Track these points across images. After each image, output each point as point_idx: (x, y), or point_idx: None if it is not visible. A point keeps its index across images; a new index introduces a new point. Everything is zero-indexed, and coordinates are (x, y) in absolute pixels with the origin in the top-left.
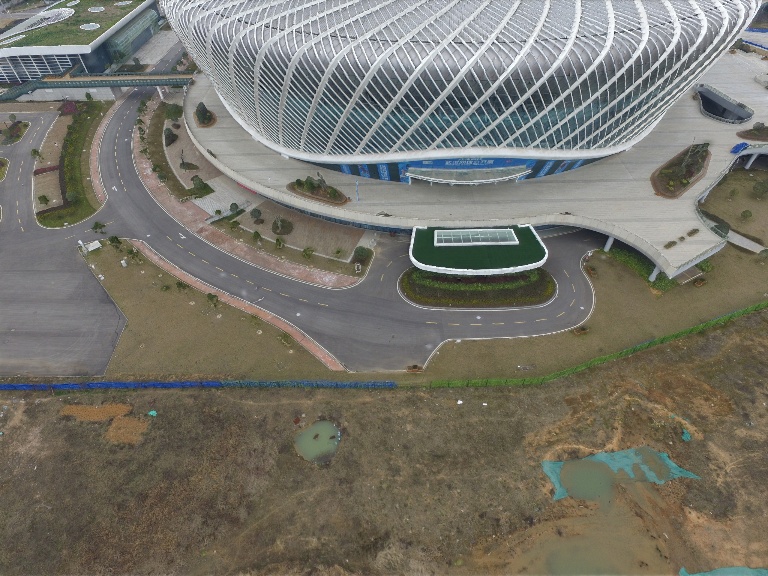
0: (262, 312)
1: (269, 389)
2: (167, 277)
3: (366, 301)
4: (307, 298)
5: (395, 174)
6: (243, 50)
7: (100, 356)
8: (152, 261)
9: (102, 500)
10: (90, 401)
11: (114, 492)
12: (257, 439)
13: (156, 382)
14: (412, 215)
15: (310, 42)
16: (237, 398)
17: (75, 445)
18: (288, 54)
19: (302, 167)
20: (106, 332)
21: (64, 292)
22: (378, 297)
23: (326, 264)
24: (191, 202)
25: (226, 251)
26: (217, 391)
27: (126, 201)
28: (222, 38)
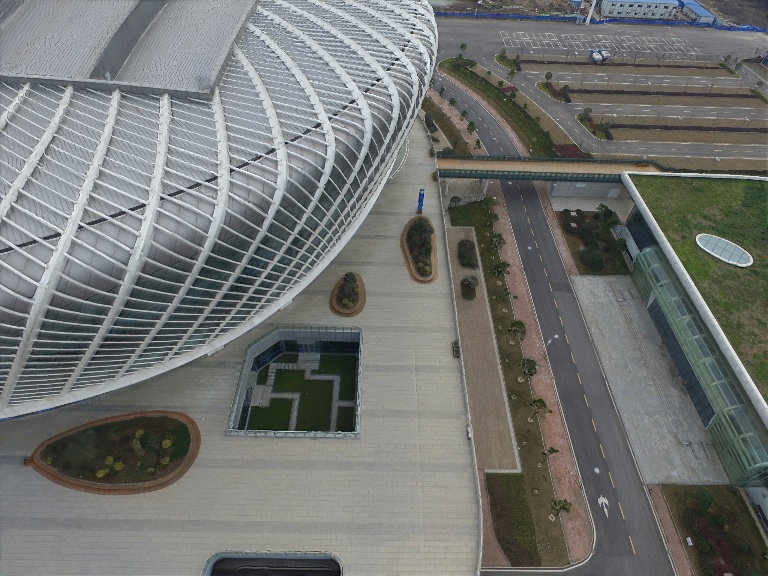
0: None
1: None
2: None
3: None
4: None
5: None
6: None
7: None
8: None
9: None
10: None
11: None
12: None
13: None
14: None
15: None
16: None
17: None
18: None
19: None
20: None
21: None
22: None
23: None
24: None
25: None
26: None
27: None
28: None
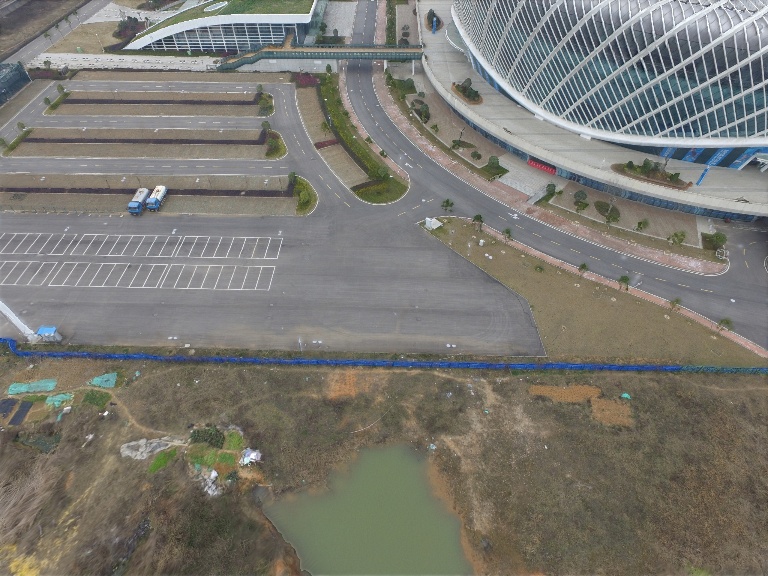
0: (651, 296)
1: (726, 375)
2: (531, 258)
3: (749, 288)
4: (686, 283)
5: (729, 159)
6: (646, 25)
7: (528, 336)
8: (503, 241)
9: (641, 482)
10: (554, 382)
11: (647, 474)
12: (749, 425)
13: (615, 365)
14: (767, 202)
15: (752, 19)
16: (700, 383)
17: (570, 426)
18: (718, 31)
19: (611, 149)
20: (515, 312)
21: (440, 270)
22: (758, 285)
23: (681, 249)
24: (498, 181)
25: (570, 233)
26: (675, 375)
27: (430, 178)
28: (619, 12)
